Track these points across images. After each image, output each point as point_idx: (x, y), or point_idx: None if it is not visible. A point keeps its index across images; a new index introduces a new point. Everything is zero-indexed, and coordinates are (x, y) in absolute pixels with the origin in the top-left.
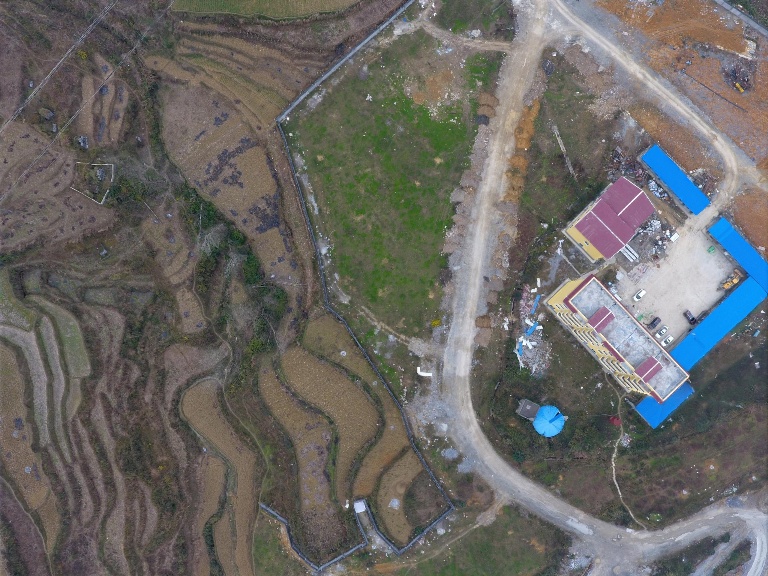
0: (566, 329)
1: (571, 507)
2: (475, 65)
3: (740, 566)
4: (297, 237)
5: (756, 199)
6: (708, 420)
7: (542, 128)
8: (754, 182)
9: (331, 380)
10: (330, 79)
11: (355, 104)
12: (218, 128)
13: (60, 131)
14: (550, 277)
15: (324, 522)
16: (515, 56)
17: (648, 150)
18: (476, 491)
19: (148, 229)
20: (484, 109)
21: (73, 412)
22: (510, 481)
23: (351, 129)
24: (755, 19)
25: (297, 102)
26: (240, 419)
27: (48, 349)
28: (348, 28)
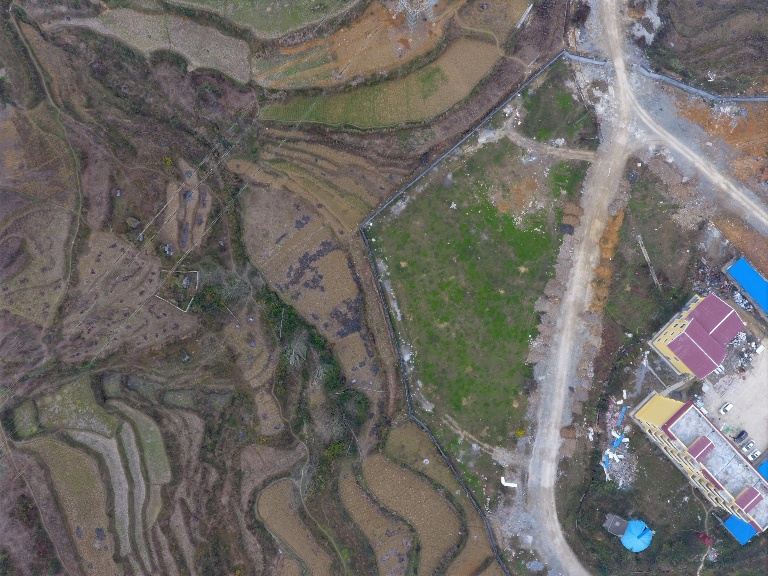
0: (652, 442)
1: None
2: (559, 174)
3: None
4: (379, 343)
5: None
6: None
7: (626, 237)
8: None
9: (413, 487)
10: (414, 186)
11: (439, 212)
12: (299, 231)
13: (171, 270)
14: (636, 389)
15: None
16: (599, 165)
17: (733, 262)
18: None
19: (230, 334)
20: (569, 219)
21: (153, 519)
22: None
23: (435, 236)
24: None
25: (381, 209)
26: (318, 522)
27: (129, 455)
28: (433, 137)
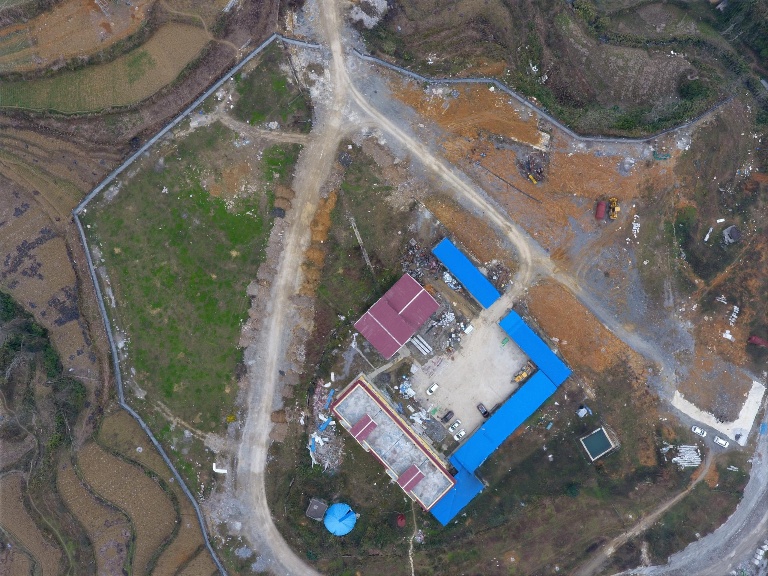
0: None
1: None
2: (272, 157)
3: None
4: (95, 330)
5: (550, 290)
6: (501, 515)
7: (339, 220)
8: (548, 273)
9: (129, 476)
10: (126, 171)
11: (151, 197)
12: (18, 219)
13: None
14: (344, 371)
15: None
16: (312, 148)
17: None
18: None
19: None
20: (279, 202)
21: None
22: None
23: (147, 222)
24: (548, 111)
25: (93, 195)
26: (42, 515)
27: None
28: (142, 121)
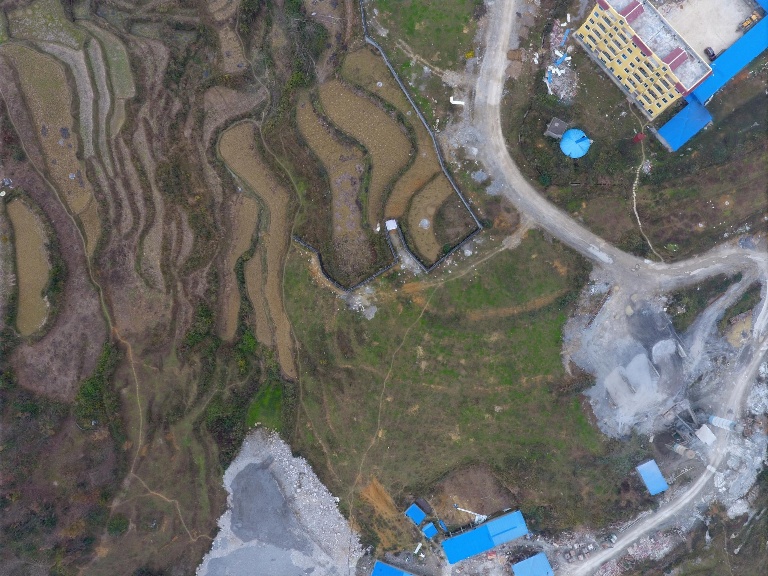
0: (593, 61)
1: (593, 235)
2: None
3: (750, 310)
4: None
5: None
6: (725, 148)
7: None
8: None
9: (366, 112)
10: None
11: None
12: None
13: None
14: (579, 13)
15: (355, 248)
16: None
17: None
18: (503, 211)
19: None
20: None
21: (117, 131)
22: (536, 206)
23: None
24: None
25: None
26: (276, 156)
27: (95, 69)
28: None
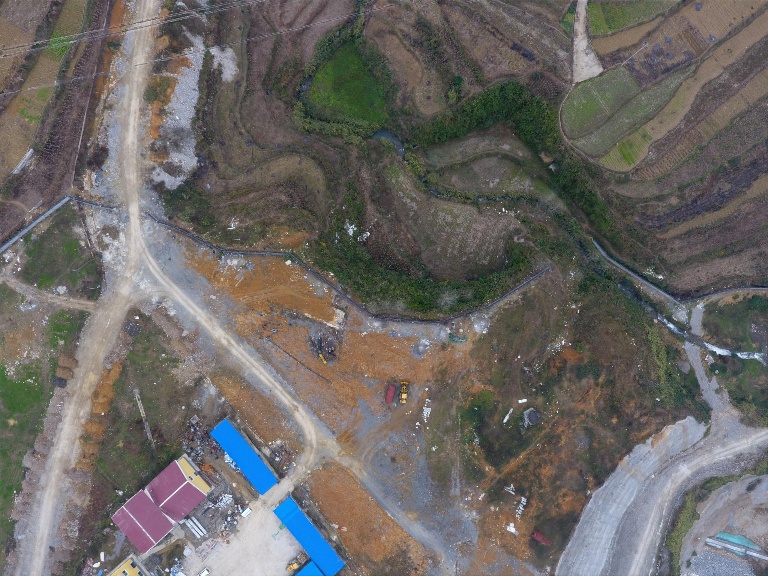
0: None
1: None
2: (58, 323)
3: None
4: None
5: (333, 474)
6: None
7: (123, 391)
8: (333, 456)
9: None
10: None
11: None
12: None
13: None
14: (115, 551)
15: None
16: (99, 316)
17: None
18: None
19: None
20: (59, 372)
21: None
22: None
23: None
24: (344, 288)
25: None
26: None
27: None
28: None
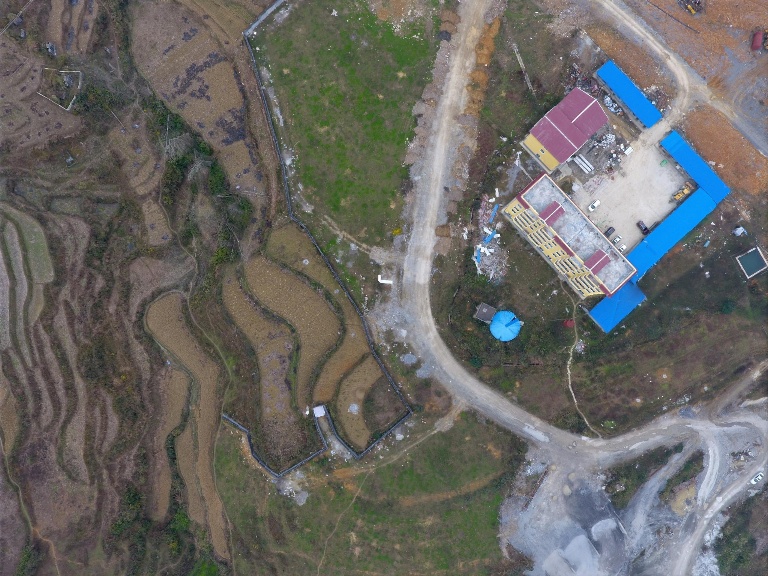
0: (523, 237)
1: (528, 414)
2: None
3: (693, 478)
4: (262, 148)
5: (707, 116)
6: (660, 327)
7: (502, 45)
8: (705, 100)
9: (294, 289)
10: None
11: (321, 19)
12: (187, 43)
13: None
14: (508, 187)
15: (285, 430)
16: None
17: None
18: (434, 396)
19: (115, 138)
20: (446, 25)
21: (35, 317)
22: (468, 387)
23: (316, 43)
24: None
25: (264, 16)
26: (204, 330)
27: (12, 254)
28: None
